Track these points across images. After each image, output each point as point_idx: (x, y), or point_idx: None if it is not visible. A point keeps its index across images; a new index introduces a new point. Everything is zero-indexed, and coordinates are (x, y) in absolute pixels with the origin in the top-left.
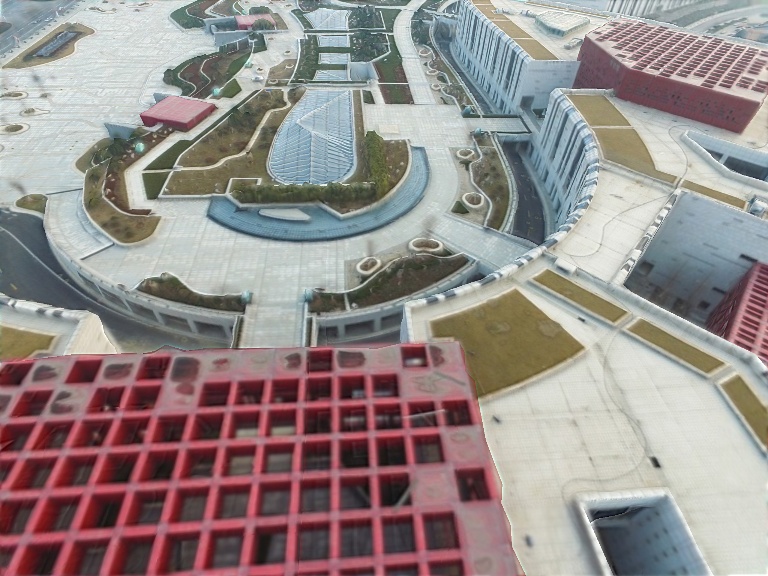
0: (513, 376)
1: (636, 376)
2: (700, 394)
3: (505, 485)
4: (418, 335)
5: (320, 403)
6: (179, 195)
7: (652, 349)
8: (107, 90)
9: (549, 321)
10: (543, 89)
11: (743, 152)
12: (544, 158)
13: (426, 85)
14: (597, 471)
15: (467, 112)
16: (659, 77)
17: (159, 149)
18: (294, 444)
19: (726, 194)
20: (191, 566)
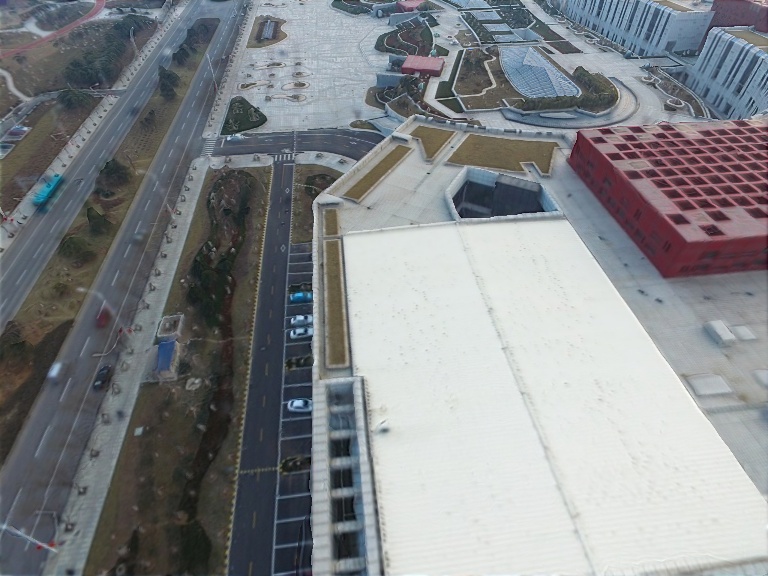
0: None
1: None
2: None
3: None
4: None
5: (759, 134)
6: (478, 109)
7: None
8: (339, 58)
9: None
10: (684, 35)
11: None
12: (704, 80)
13: (582, 41)
14: None
15: (629, 55)
16: None
17: (432, 87)
18: (762, 144)
19: None
20: (764, 169)
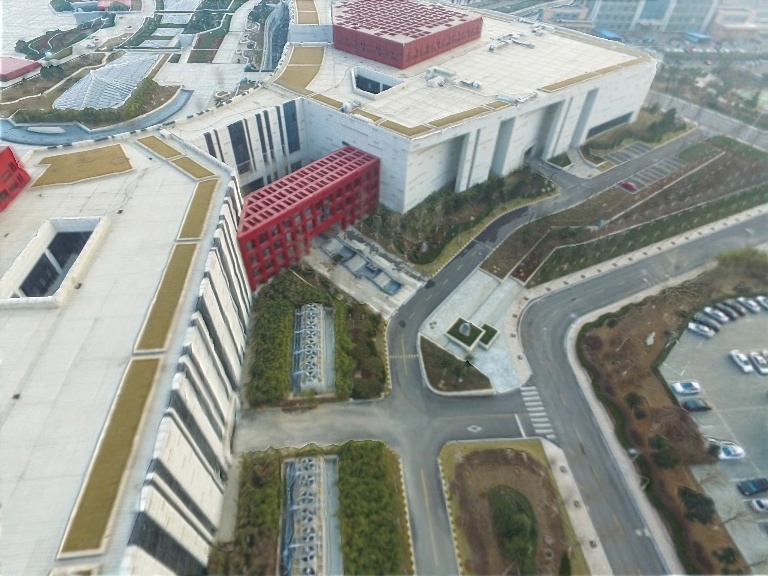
0: (70, 179)
1: (154, 181)
2: (184, 188)
3: (15, 217)
4: (30, 164)
5: None
6: None
7: (178, 170)
8: None
9: (124, 158)
10: None
11: (388, 79)
12: None
13: (232, 50)
14: (79, 214)
15: (248, 68)
16: (350, 29)
17: None
18: None
19: (338, 101)
20: None
